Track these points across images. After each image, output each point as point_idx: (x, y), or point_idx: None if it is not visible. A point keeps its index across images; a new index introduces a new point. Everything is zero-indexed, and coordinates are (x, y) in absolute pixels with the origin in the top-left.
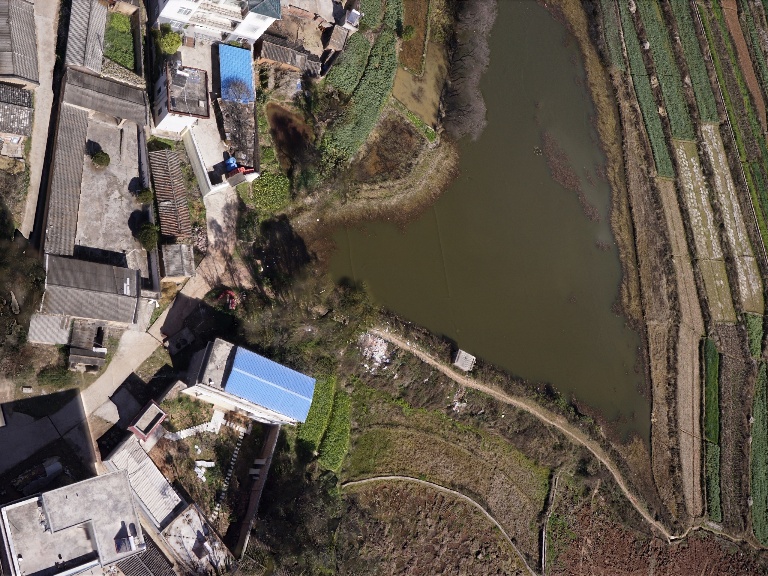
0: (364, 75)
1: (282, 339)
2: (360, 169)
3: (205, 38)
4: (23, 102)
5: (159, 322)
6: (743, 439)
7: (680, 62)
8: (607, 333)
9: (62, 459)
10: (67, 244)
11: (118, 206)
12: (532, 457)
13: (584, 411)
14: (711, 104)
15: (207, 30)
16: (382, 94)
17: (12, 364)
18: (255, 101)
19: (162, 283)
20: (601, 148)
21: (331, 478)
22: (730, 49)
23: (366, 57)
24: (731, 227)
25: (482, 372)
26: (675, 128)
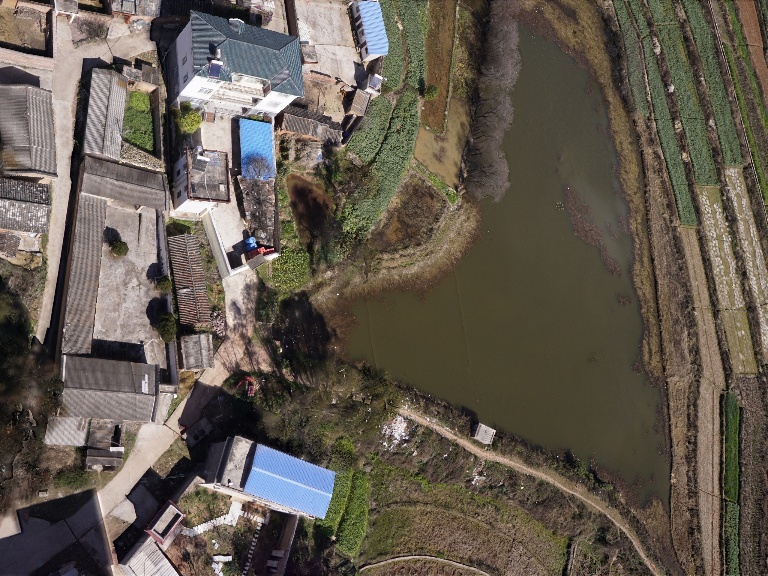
0: (386, 139)
1: (301, 423)
2: (381, 237)
3: (225, 112)
4: (41, 199)
5: (177, 413)
6: (763, 496)
7: (704, 104)
8: (627, 393)
9: (78, 564)
10: (85, 342)
11: (136, 295)
12: (551, 527)
13: (603, 476)
14: (735, 147)
15: (227, 104)
16: (404, 158)
17: (28, 467)
18: (276, 177)
19: (180, 373)
20: (623, 198)
21: (350, 569)
22: (755, 88)
23: (388, 119)
24: (754, 275)
25: (502, 444)
26: (698, 174)
